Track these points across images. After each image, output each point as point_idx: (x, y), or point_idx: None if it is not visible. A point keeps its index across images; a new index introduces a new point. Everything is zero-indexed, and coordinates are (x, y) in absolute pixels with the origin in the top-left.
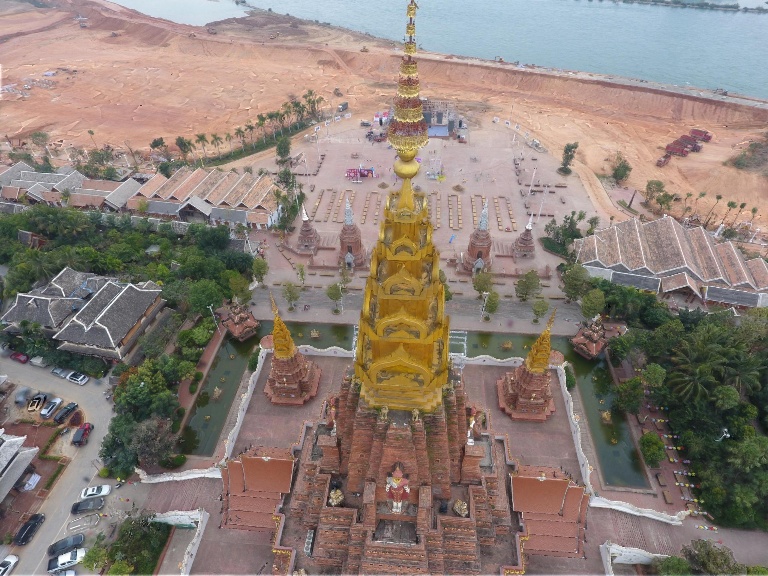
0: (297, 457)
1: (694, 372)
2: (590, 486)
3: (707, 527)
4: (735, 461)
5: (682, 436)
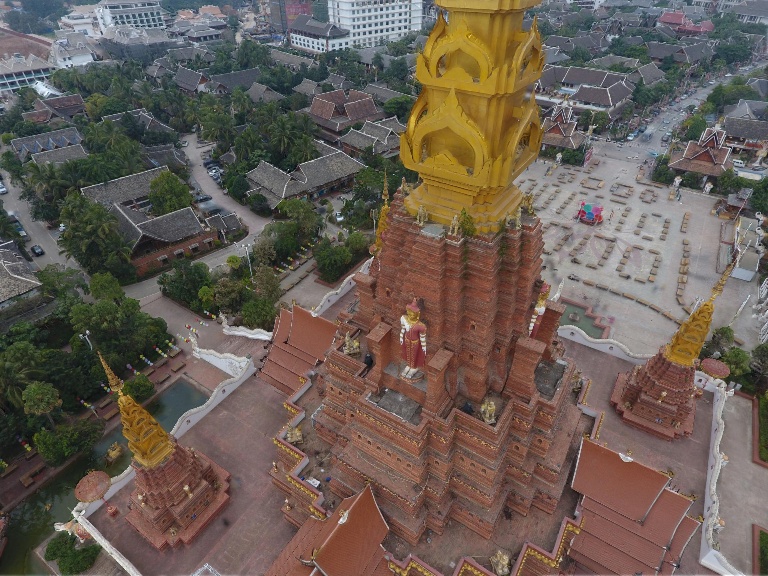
0: (570, 513)
1: (5, 376)
2: (242, 372)
3: (191, 328)
4: (120, 316)
5: (102, 376)
